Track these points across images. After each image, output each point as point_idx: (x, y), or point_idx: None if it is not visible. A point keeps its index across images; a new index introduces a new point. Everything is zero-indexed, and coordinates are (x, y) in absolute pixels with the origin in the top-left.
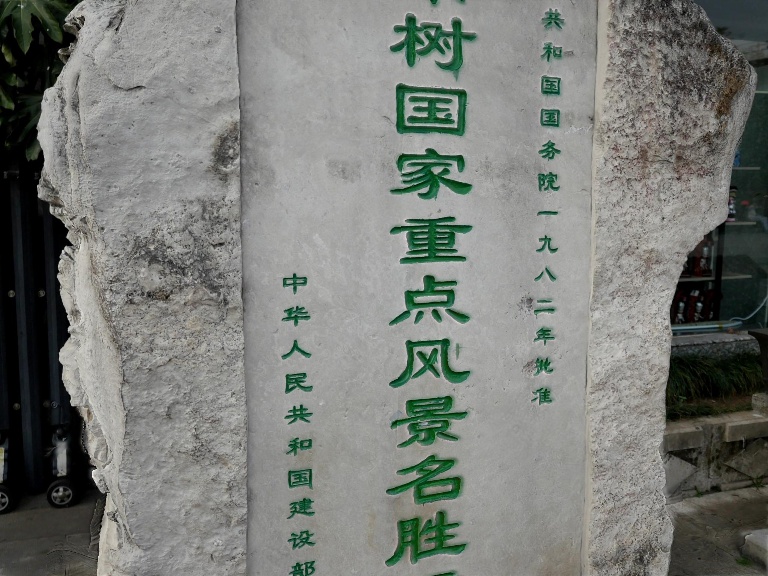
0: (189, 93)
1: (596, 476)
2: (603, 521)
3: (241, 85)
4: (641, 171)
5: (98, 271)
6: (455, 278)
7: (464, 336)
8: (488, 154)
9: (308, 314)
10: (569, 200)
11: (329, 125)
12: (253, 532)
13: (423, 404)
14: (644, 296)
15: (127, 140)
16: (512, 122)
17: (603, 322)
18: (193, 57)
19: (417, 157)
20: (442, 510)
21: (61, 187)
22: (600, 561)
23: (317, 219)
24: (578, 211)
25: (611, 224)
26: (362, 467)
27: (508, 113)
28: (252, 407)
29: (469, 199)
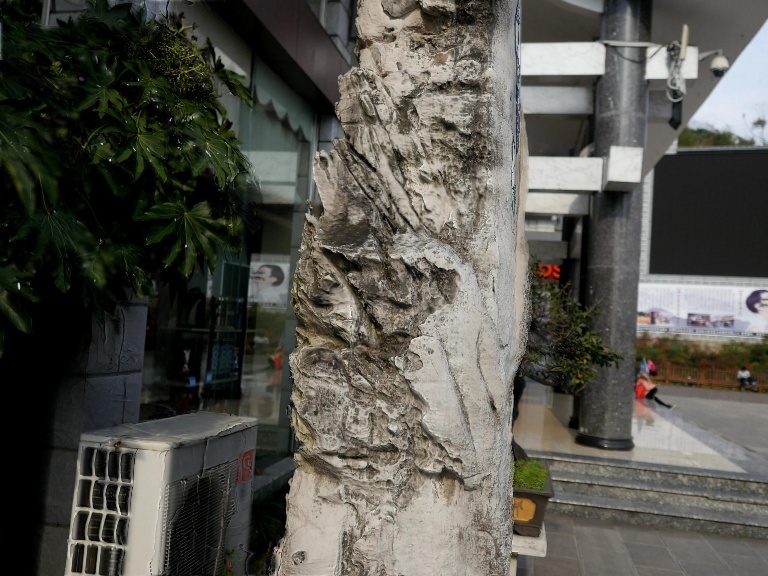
0: None
1: None
2: None
3: None
4: None
5: (493, 527)
6: None
7: None
8: None
9: None
10: None
11: None
12: None
13: None
14: None
15: None
16: None
17: None
18: None
19: None
20: None
21: (468, 445)
22: None
23: None
24: None
25: None
26: None
27: None
28: None
29: None
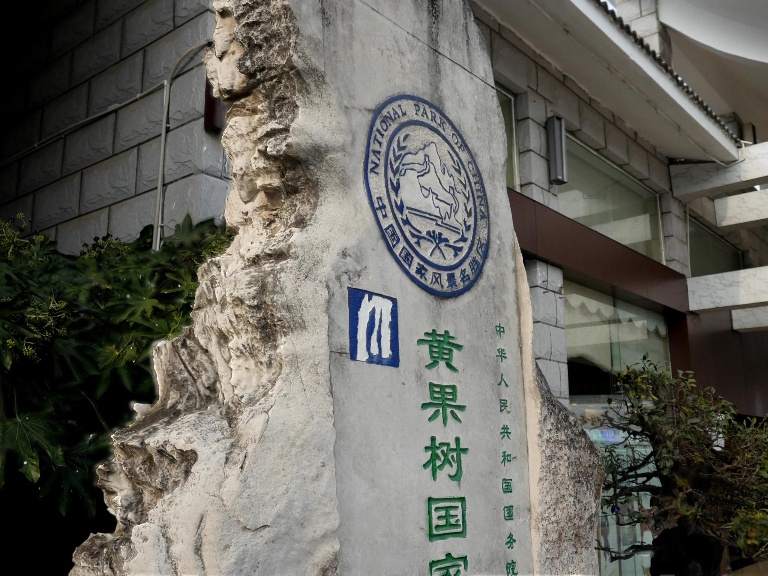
0: (301, 527)
1: None
2: None
3: None
4: (558, 550)
5: None
6: None
7: None
8: (480, 551)
9: None
10: None
11: (389, 542)
12: None
13: None
14: None
15: None
16: (491, 521)
17: None
18: (305, 492)
19: (440, 562)
20: None
21: None
22: None
23: None
24: None
25: None
26: None
27: (488, 513)
28: None
29: None
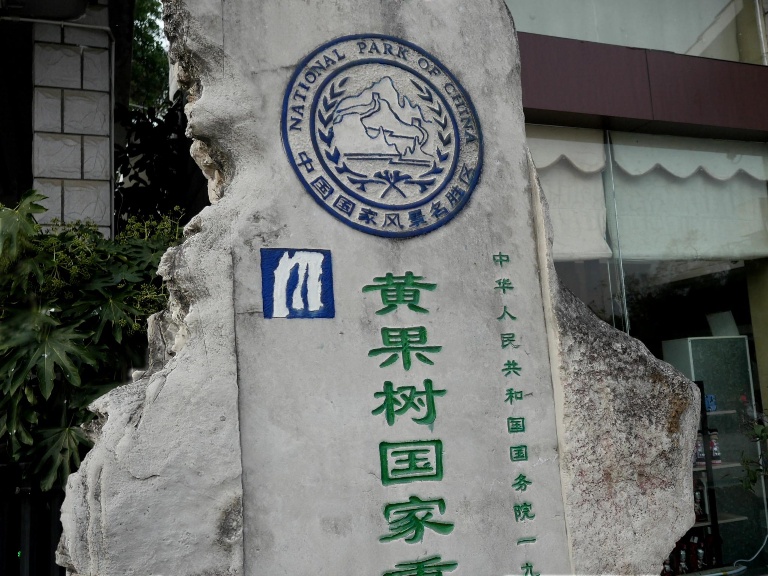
0: (198, 476)
1: None
2: None
3: (243, 462)
4: (608, 492)
5: None
6: None
7: None
8: (466, 494)
9: None
10: (545, 527)
11: (321, 487)
12: None
13: None
14: None
15: (142, 525)
16: (485, 462)
17: None
18: (201, 444)
19: (402, 505)
20: None
21: (81, 571)
22: None
23: (314, 575)
24: (555, 536)
25: (587, 545)
26: None
27: (480, 455)
28: None
29: (452, 538)
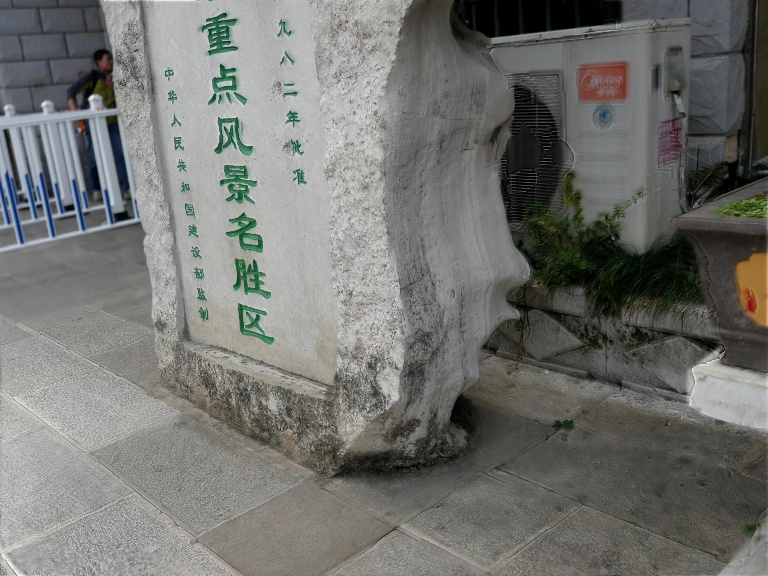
0: None
1: (336, 264)
2: (345, 311)
3: None
4: None
5: None
6: (233, 65)
7: (244, 115)
8: None
9: (176, 96)
10: None
11: None
12: (177, 239)
13: (234, 170)
14: (360, 77)
15: None
16: None
17: (328, 106)
18: None
19: None
20: (255, 259)
21: None
22: (346, 350)
23: None
24: None
25: None
26: (213, 211)
27: None
28: (166, 157)
29: None
